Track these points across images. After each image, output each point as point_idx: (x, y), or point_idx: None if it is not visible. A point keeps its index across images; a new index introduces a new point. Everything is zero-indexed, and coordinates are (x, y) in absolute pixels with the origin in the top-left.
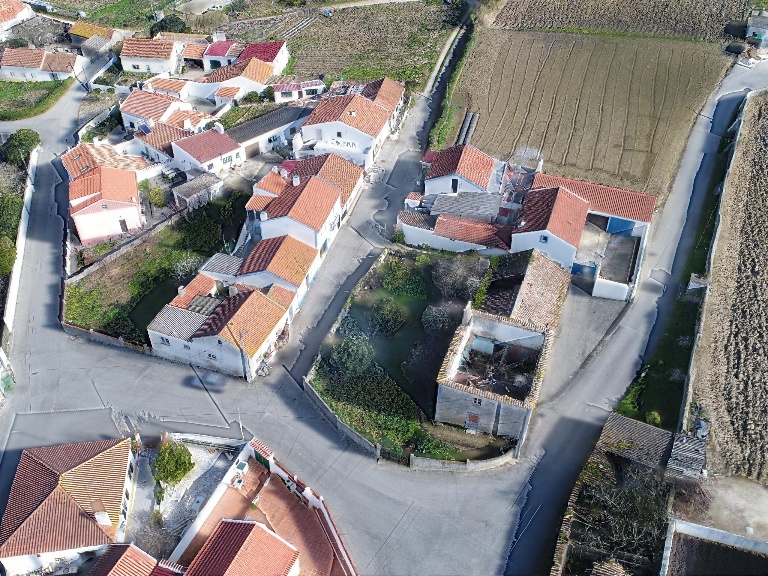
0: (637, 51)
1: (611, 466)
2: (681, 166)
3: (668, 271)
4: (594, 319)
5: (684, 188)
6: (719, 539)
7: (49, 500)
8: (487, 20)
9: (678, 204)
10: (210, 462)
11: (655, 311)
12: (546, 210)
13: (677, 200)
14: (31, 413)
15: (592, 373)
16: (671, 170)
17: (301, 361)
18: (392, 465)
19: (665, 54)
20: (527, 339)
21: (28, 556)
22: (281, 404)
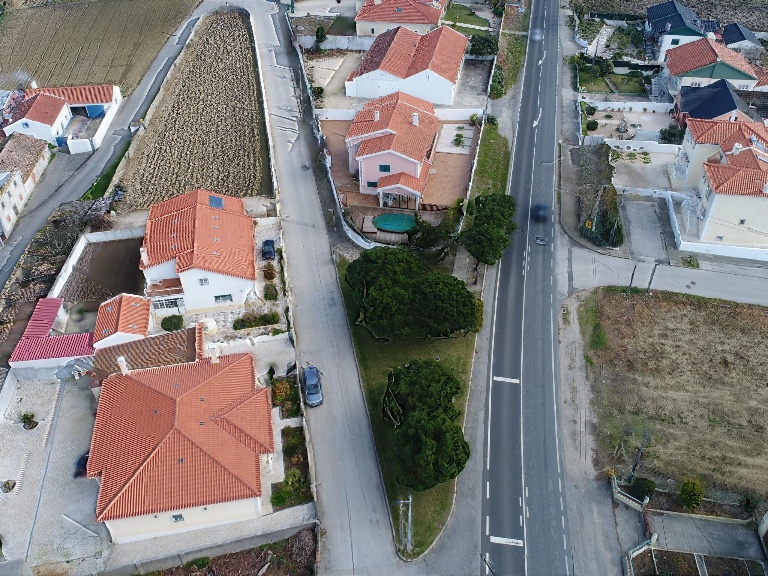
0: (135, 3)
1: (55, 226)
2: (150, 68)
3: (126, 128)
4: (69, 166)
5: (149, 81)
6: (113, 237)
7: None
8: (17, 3)
9: (142, 90)
10: None
11: (112, 151)
12: (28, 108)
13: (142, 88)
14: None
15: (62, 192)
16: (142, 72)
17: None
18: None
19: (156, 1)
20: (4, 180)
21: None
22: None
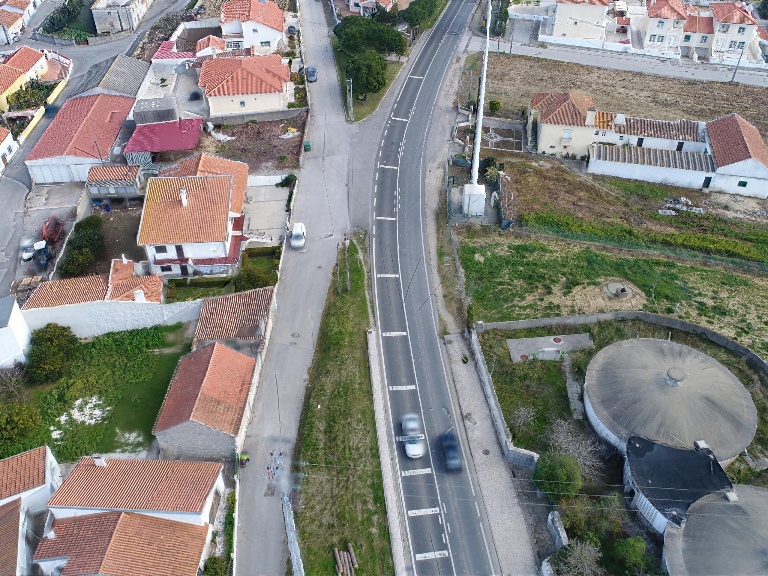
0: None
1: None
2: None
3: None
4: (168, 2)
5: None
6: (200, 26)
7: None
8: None
9: None
10: None
11: None
12: None
13: None
14: None
15: None
16: None
17: (34, 35)
18: (82, 46)
19: None
20: (131, 0)
21: None
22: (28, 45)
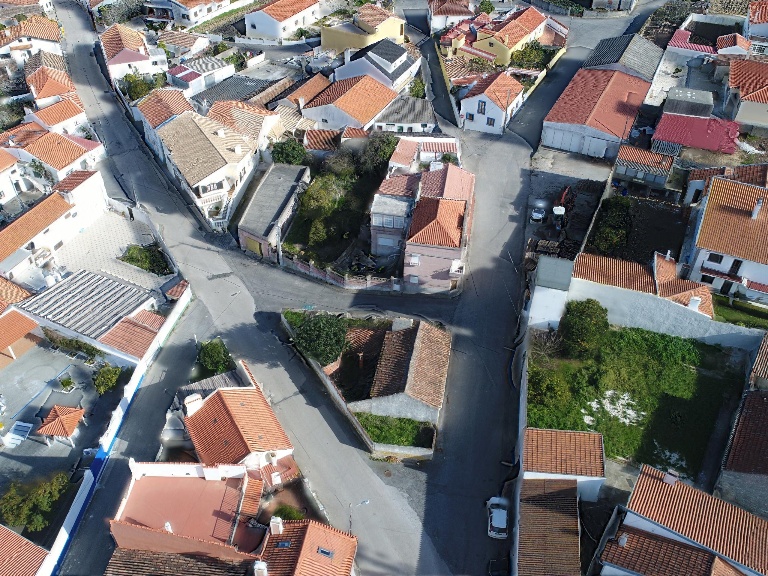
0: None
1: None
2: None
3: None
4: None
5: None
6: (710, 21)
7: (449, 2)
8: None
9: None
10: (497, 16)
11: None
12: None
13: None
14: (410, 9)
15: None
16: None
17: None
18: (575, 17)
19: None
20: None
21: (443, 18)
22: None
